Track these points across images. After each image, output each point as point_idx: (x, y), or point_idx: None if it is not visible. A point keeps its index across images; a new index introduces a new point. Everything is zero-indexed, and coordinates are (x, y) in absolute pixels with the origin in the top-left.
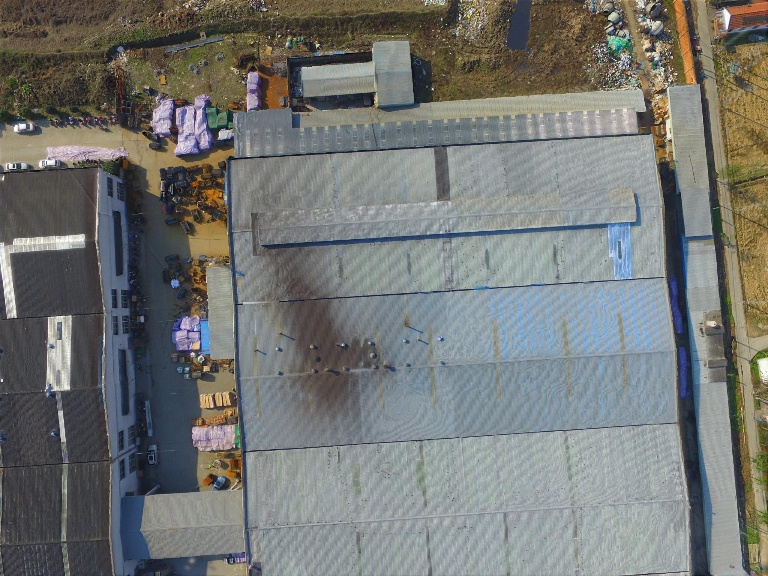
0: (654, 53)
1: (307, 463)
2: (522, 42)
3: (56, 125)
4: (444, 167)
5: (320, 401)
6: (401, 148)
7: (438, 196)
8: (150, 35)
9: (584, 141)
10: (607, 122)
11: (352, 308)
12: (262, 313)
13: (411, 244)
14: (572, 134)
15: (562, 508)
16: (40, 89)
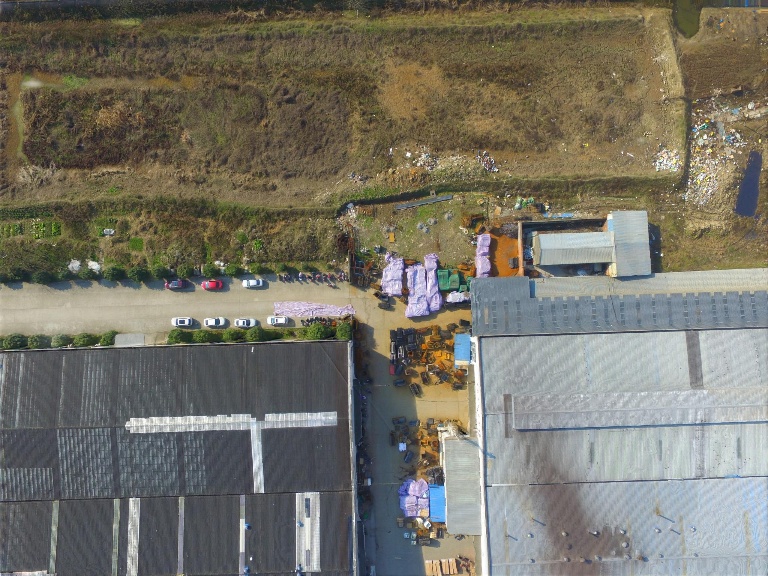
0: None
1: None
2: (751, 209)
3: (284, 280)
4: (696, 352)
5: None
6: (653, 331)
7: (691, 382)
8: (382, 193)
9: None
10: None
11: (602, 494)
12: (512, 496)
13: (664, 431)
14: None
15: None
16: (270, 244)
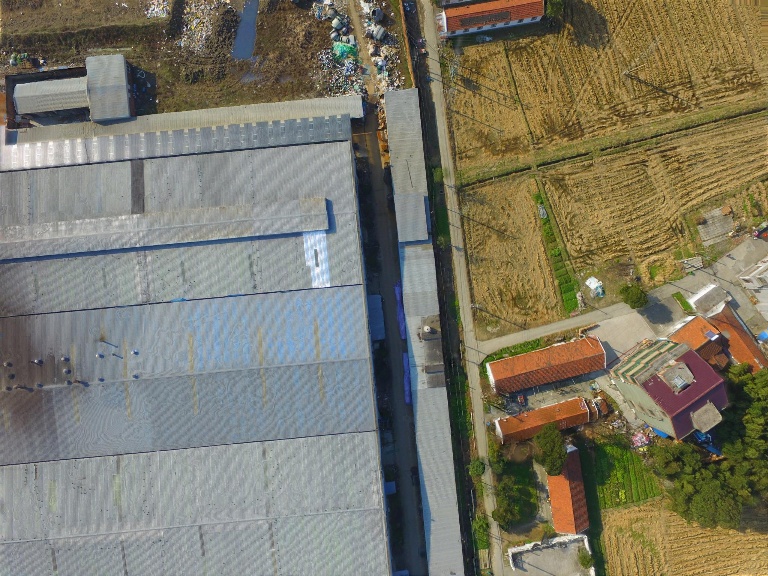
0: (377, 58)
1: (4, 481)
2: (248, 51)
3: None
4: (140, 180)
5: (15, 418)
6: (98, 162)
7: (132, 209)
8: None
9: (281, 150)
10: (320, 129)
11: (48, 324)
12: None
13: (105, 258)
14: (284, 142)
15: (257, 520)
16: None
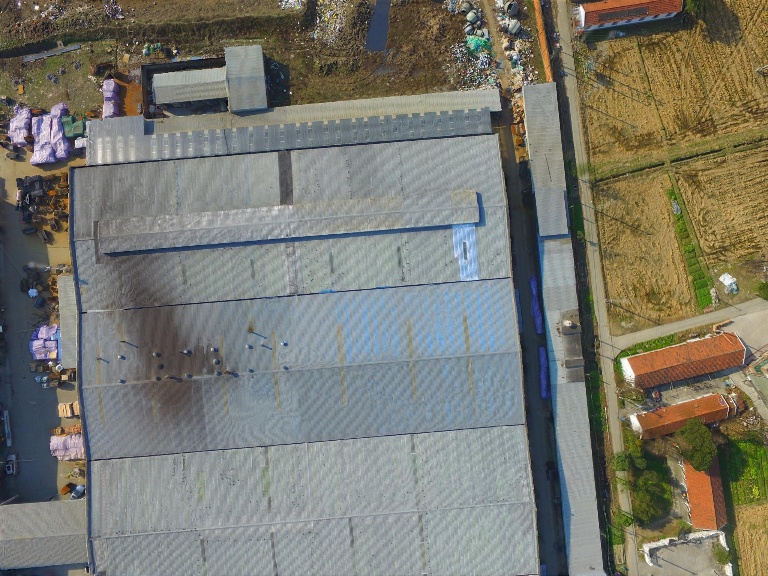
0: (512, 52)
1: (152, 471)
2: (381, 44)
3: None
4: (288, 171)
5: (163, 408)
6: (245, 153)
7: (281, 200)
8: (6, 45)
9: (429, 142)
10: (460, 122)
11: (196, 314)
12: (106, 321)
13: (254, 249)
14: (424, 135)
15: (407, 512)
16: None
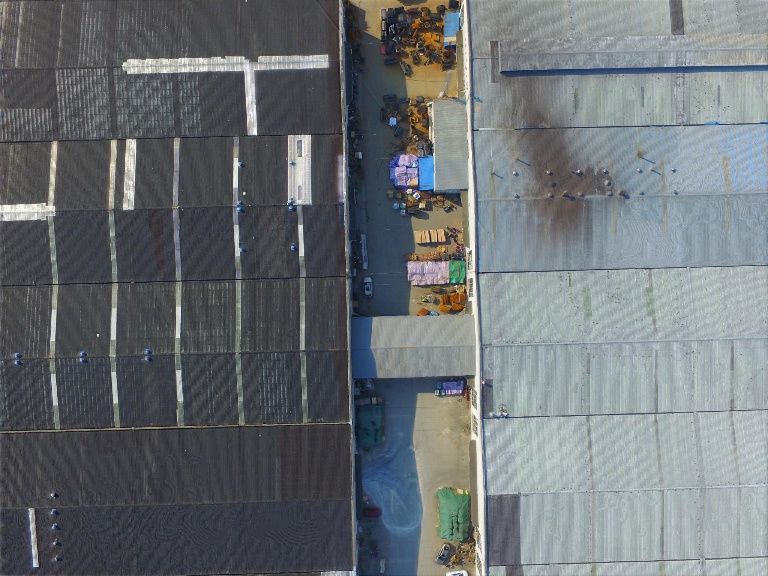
0: None
1: (539, 286)
2: None
3: None
4: (678, 5)
5: (554, 225)
6: None
7: (672, 32)
8: None
9: None
10: None
11: (586, 138)
12: (498, 139)
13: (645, 77)
14: None
15: None
16: None
